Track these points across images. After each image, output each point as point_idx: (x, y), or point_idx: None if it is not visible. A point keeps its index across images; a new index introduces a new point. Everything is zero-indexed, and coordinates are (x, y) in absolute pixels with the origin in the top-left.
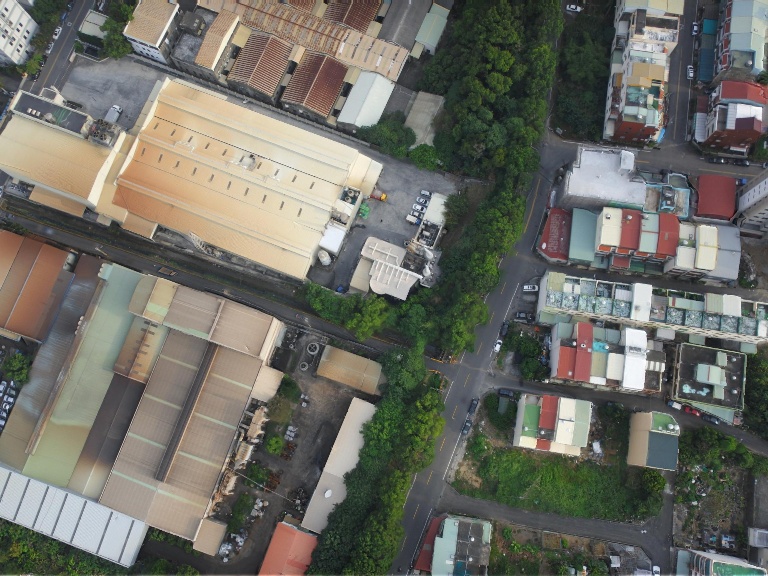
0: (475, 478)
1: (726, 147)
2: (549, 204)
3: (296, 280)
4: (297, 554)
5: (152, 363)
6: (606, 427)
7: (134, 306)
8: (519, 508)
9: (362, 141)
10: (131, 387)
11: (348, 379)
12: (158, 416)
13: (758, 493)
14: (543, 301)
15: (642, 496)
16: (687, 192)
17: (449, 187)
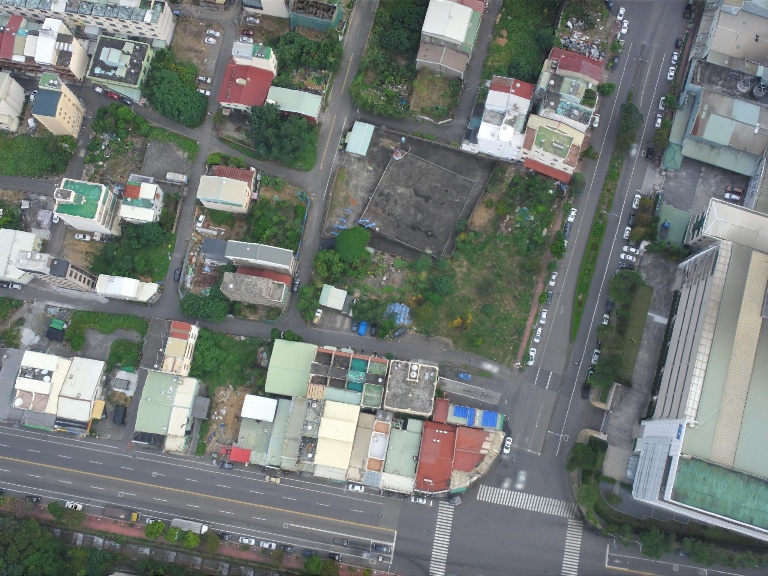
0: None
1: None
2: None
3: None
4: None
5: None
6: None
7: None
8: None
9: None
10: None
11: None
12: None
13: (148, 153)
14: None
15: None
16: None
17: None
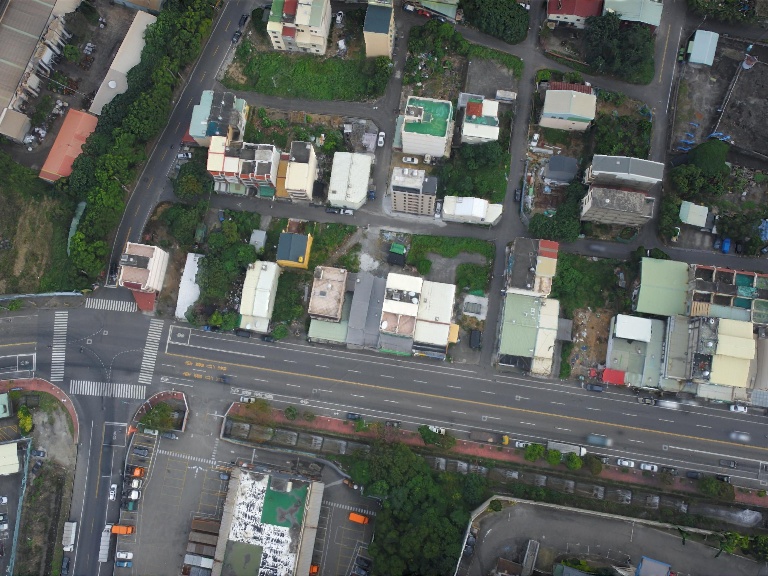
0: (241, 76)
1: None
2: None
3: None
4: (83, 130)
5: None
6: (352, 30)
7: None
8: (275, 96)
9: None
10: None
11: None
12: None
13: (470, 72)
14: None
15: None
16: None
17: None
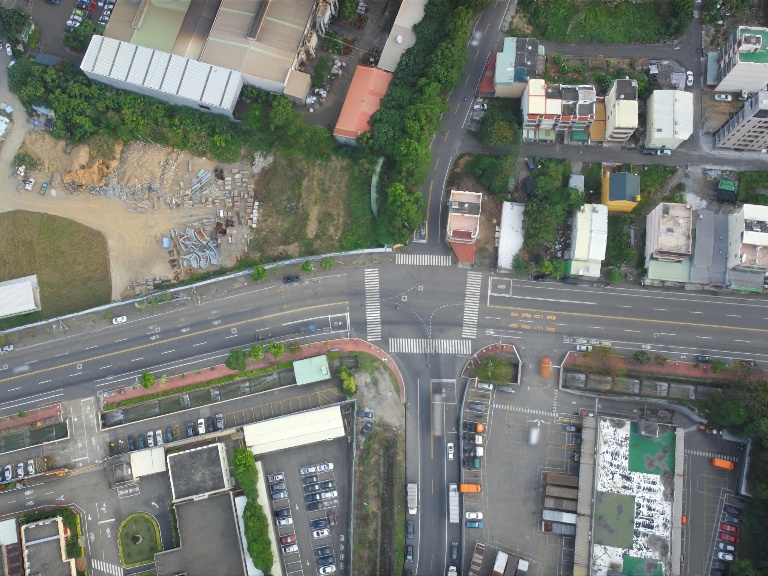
0: (527, 26)
1: None
2: None
3: None
4: (376, 86)
5: None
6: None
7: None
8: (567, 43)
9: None
10: None
11: None
12: None
13: None
14: None
15: None
16: None
17: None
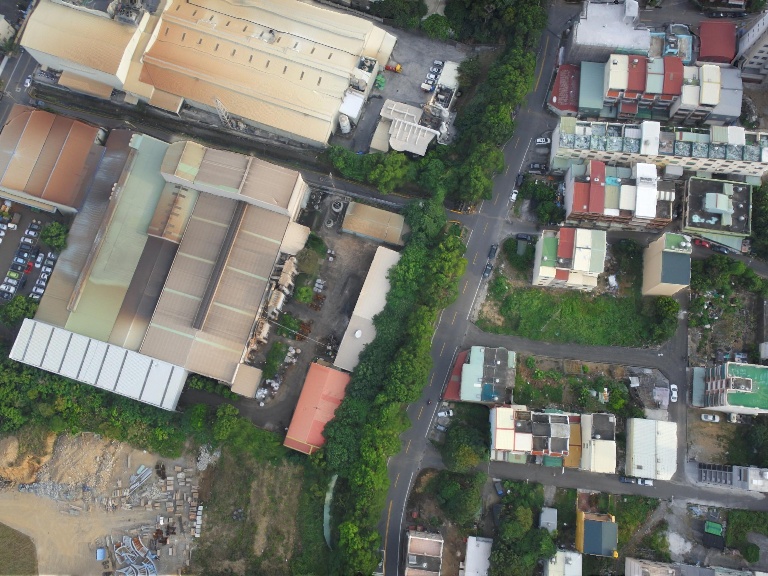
0: (497, 317)
1: (724, 1)
2: (558, 62)
3: (318, 147)
4: (331, 390)
5: (184, 224)
6: (620, 263)
7: (166, 167)
8: (541, 341)
9: (376, 17)
10: (165, 247)
11: (372, 231)
12: (192, 271)
13: (767, 313)
14: (556, 146)
15: (657, 321)
16: (689, 38)
17: (461, 57)
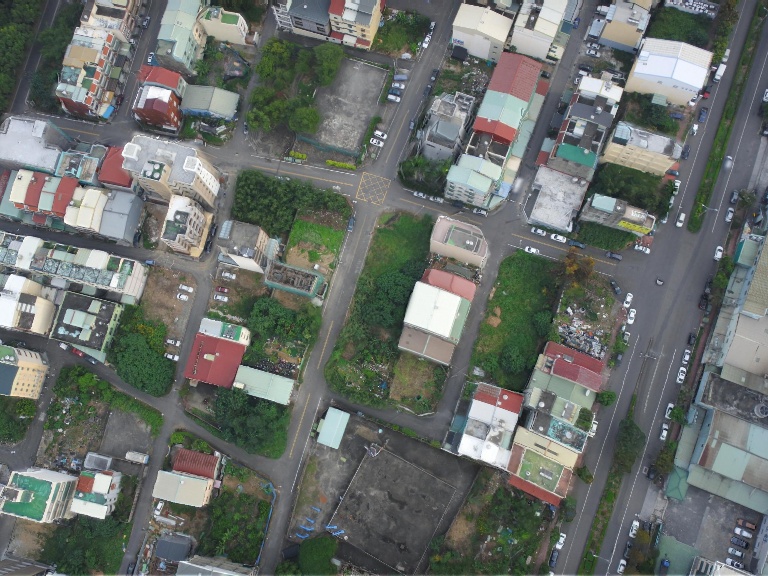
0: None
1: (158, 125)
2: None
3: None
4: None
5: None
6: None
7: None
8: None
9: None
10: None
11: None
12: None
13: (109, 424)
14: None
15: None
16: (97, 161)
17: None
